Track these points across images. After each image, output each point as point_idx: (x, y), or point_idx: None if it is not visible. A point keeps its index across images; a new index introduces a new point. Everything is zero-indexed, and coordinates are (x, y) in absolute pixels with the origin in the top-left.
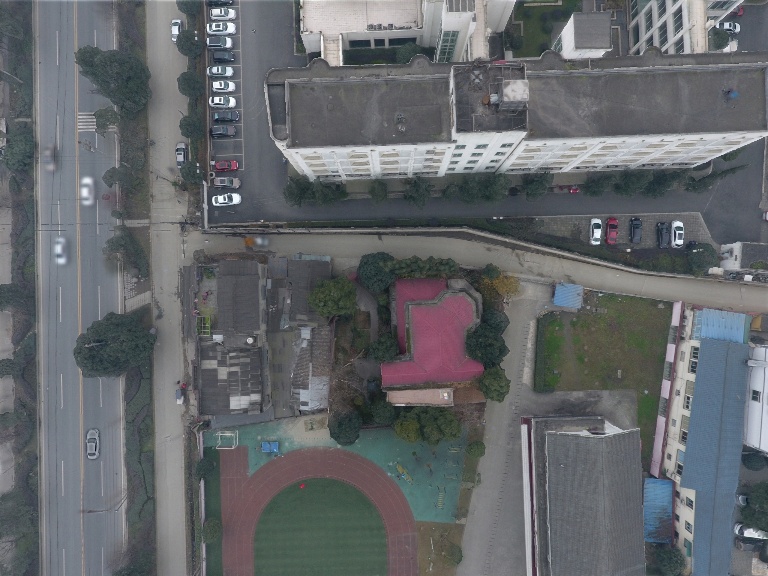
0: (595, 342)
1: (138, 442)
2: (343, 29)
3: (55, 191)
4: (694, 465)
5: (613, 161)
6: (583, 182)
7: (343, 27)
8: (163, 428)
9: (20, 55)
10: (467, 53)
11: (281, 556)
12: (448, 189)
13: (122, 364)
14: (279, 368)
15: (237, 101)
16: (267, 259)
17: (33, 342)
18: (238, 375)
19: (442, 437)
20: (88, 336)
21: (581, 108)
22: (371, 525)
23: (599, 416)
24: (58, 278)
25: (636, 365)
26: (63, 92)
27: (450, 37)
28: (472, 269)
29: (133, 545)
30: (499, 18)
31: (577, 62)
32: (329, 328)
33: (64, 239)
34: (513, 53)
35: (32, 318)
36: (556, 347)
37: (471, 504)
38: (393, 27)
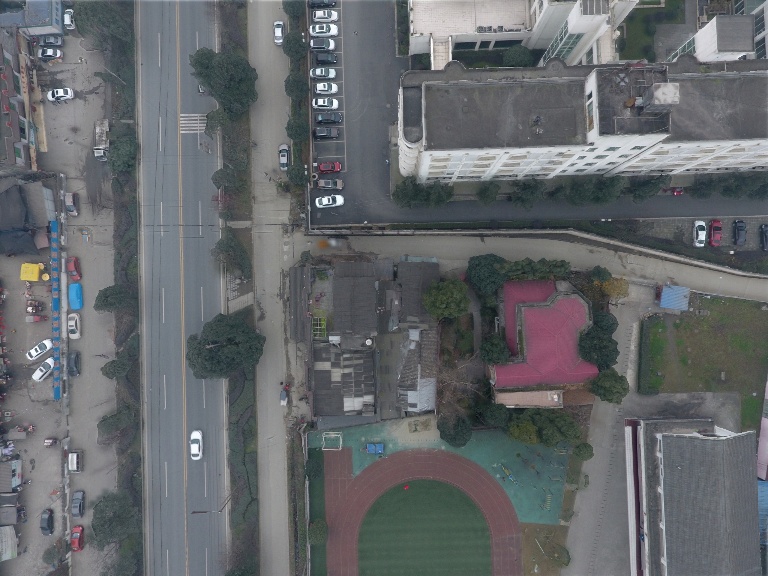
0: (698, 344)
1: (242, 443)
2: (452, 31)
3: (157, 192)
4: None
5: (729, 163)
6: (691, 184)
7: (452, 29)
8: (266, 429)
9: (123, 57)
10: (589, 55)
11: (385, 557)
12: (562, 191)
13: (233, 365)
14: (386, 370)
15: (339, 103)
16: (370, 261)
17: (137, 343)
18: (352, 377)
19: (563, 439)
20: (206, 337)
21: (716, 111)
22: (475, 527)
23: (709, 418)
24: (161, 279)
25: (740, 367)
26: (165, 94)
27: (573, 39)
28: (579, 271)
29: (237, 546)
30: None
31: (712, 65)
32: (436, 330)
33: (167, 240)
34: None
35: (136, 319)
36: (659, 349)
37: (575, 506)
38: (503, 29)
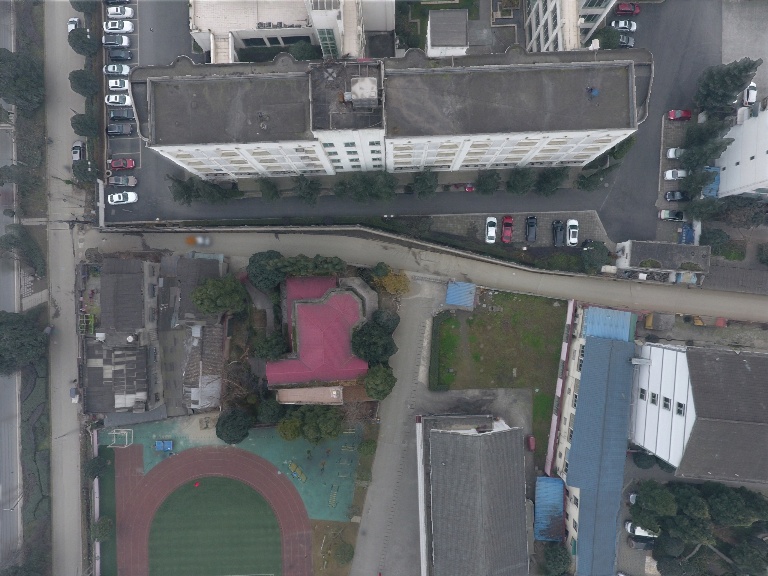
0: (491, 340)
1: (33, 441)
2: (234, 27)
3: None
4: (578, 463)
5: (496, 159)
6: (474, 180)
7: (234, 25)
8: (59, 427)
9: None
10: None
11: (176, 555)
12: None
13: (10, 362)
14: (171, 366)
15: None
16: None
17: None
18: (123, 373)
19: (319, 435)
20: None
21: (445, 106)
22: (266, 523)
23: (488, 414)
24: None
25: (531, 363)
26: None
27: (327, 35)
28: (364, 267)
29: (28, 544)
30: (384, 16)
31: (441, 60)
32: (221, 326)
33: None
34: None
35: None
36: (452, 345)
37: (366, 502)
38: (282, 25)
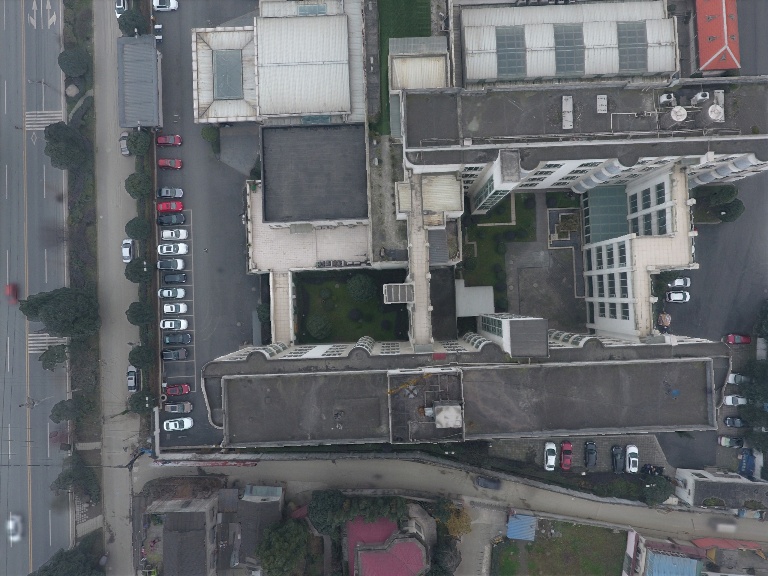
0: (550, 567)
1: None
2: (293, 263)
3: (5, 414)
4: None
5: None
6: None
7: (293, 261)
8: None
9: None
10: None
11: None
12: None
13: None
14: None
15: (189, 322)
16: (219, 483)
17: None
18: None
19: None
20: None
21: (521, 399)
22: None
23: None
24: (8, 503)
25: None
26: (13, 313)
27: None
28: (424, 501)
29: None
30: None
31: None
32: None
33: (14, 463)
34: (467, 273)
35: None
36: (511, 572)
37: None
38: (342, 264)
